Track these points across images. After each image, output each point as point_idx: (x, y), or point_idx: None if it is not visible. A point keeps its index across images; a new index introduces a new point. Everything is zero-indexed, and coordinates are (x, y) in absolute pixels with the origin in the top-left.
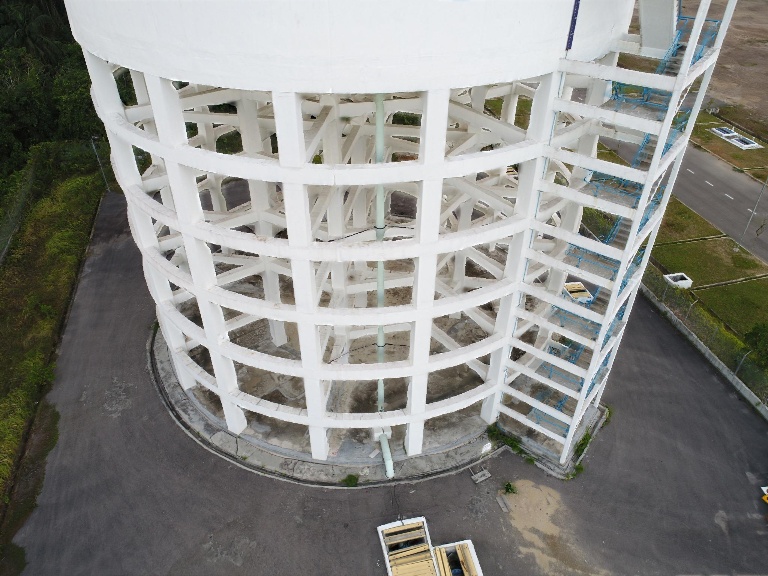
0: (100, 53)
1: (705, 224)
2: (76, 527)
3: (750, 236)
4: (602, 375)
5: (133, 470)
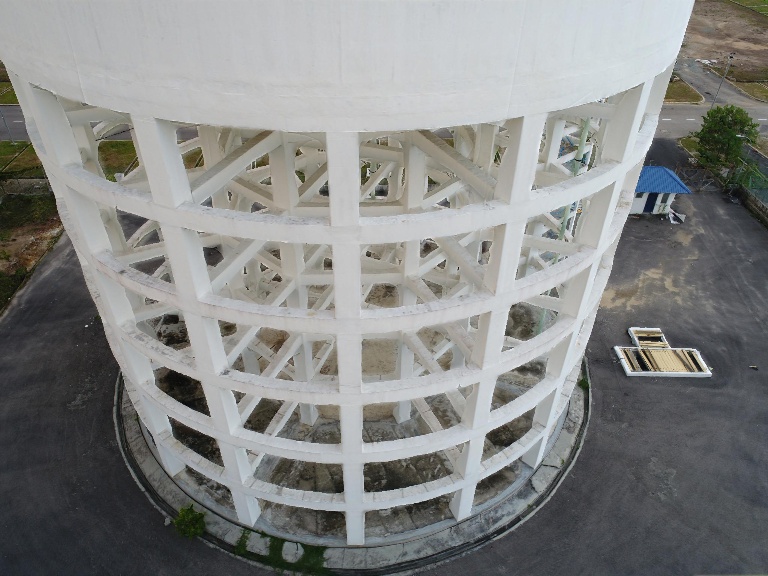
0: (593, 95)
1: None
2: None
3: None
4: None
5: (582, 575)
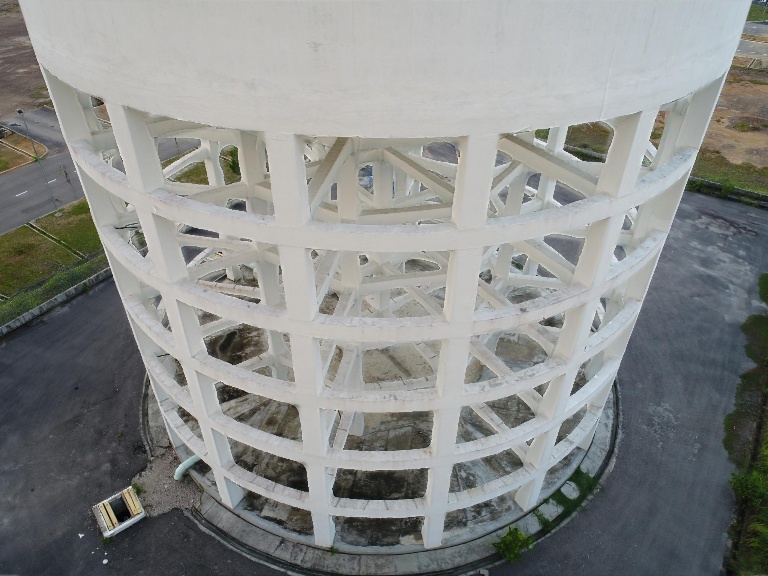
0: None
1: (7, 236)
2: (708, 346)
3: (19, 215)
4: (362, 177)
5: (660, 354)
